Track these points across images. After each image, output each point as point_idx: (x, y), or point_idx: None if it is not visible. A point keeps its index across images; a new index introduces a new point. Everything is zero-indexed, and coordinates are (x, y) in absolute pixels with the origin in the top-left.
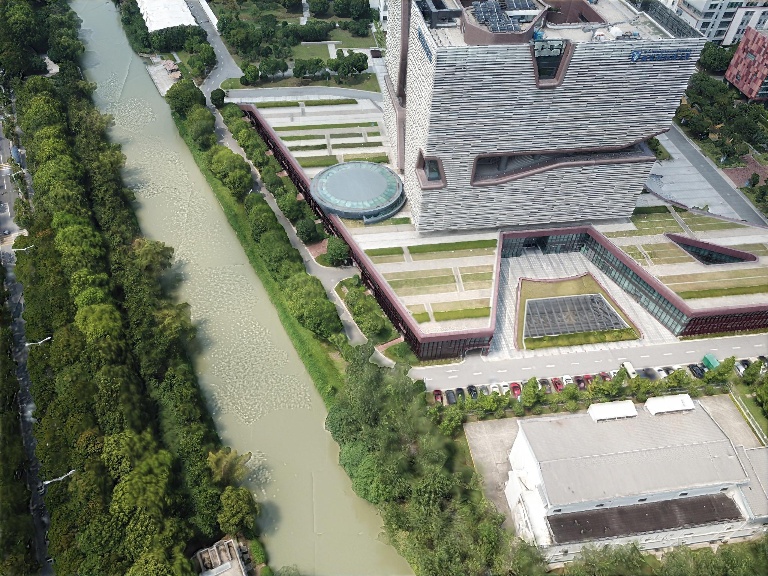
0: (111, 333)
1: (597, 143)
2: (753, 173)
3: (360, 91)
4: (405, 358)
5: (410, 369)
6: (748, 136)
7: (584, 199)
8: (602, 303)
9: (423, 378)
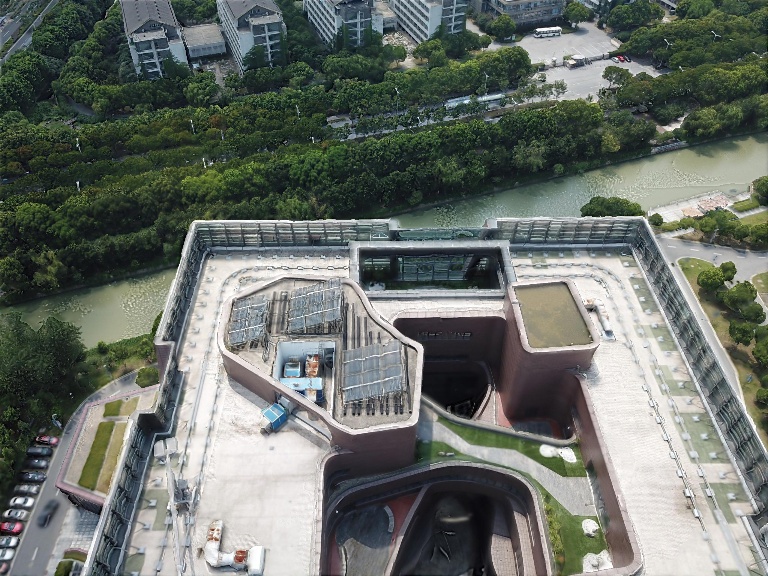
0: (186, 189)
1: None
2: None
3: None
4: None
5: None
6: None
7: None
8: None
9: None
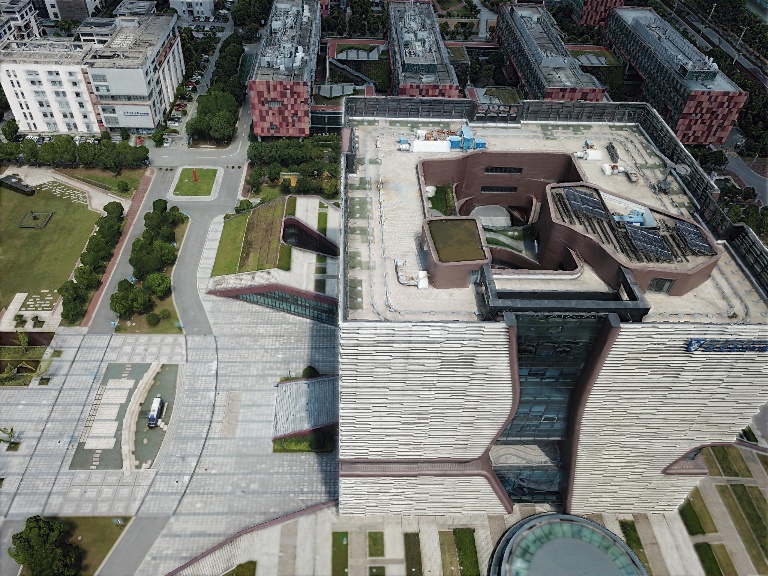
0: None
1: None
2: None
3: (109, 560)
4: None
5: None
6: None
7: None
8: None
9: None
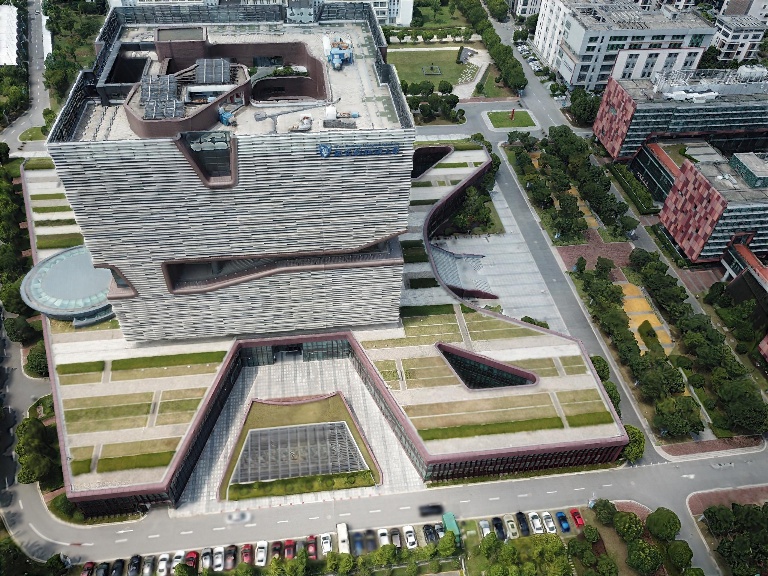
0: None
1: (318, 246)
2: (580, 257)
3: None
4: (68, 514)
5: (72, 528)
6: (595, 206)
7: (328, 305)
8: (344, 434)
9: (61, 552)
